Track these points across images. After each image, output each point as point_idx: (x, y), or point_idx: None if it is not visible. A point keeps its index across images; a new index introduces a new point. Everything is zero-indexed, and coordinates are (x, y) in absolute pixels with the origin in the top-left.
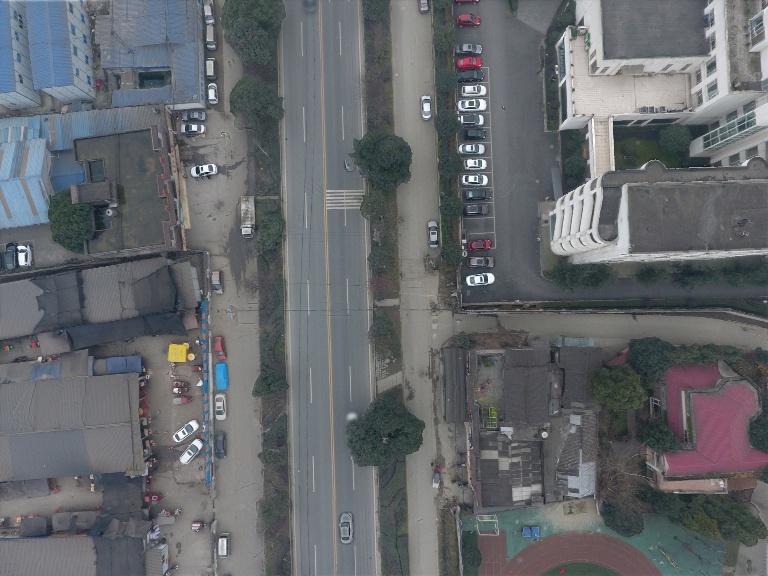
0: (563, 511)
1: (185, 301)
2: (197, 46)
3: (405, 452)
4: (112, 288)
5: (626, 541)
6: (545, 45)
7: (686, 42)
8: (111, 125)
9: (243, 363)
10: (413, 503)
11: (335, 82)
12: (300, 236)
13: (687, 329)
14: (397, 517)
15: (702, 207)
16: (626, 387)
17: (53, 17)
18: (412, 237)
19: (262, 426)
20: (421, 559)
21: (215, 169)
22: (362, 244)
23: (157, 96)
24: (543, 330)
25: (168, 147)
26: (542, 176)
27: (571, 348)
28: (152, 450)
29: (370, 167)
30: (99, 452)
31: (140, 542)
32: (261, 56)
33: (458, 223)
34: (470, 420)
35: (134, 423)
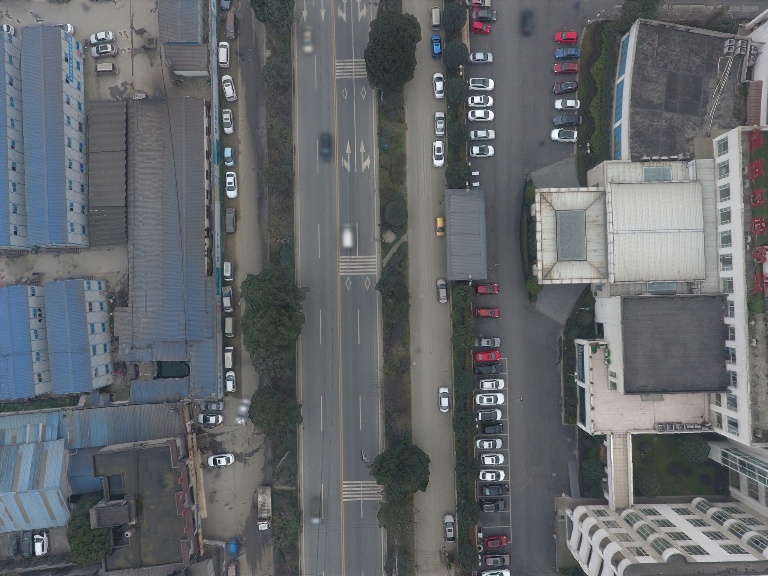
0: None
1: None
2: (216, 343)
3: None
4: None
5: None
6: (564, 337)
7: (707, 372)
8: (129, 422)
9: None
10: None
11: (353, 371)
12: (316, 527)
13: None
14: None
15: None
16: None
17: (73, 323)
18: (428, 528)
19: None
20: None
21: (232, 460)
22: (378, 536)
23: (175, 391)
24: None
25: (186, 450)
26: (559, 470)
27: None
28: None
29: (388, 484)
30: None
31: None
32: (281, 373)
33: None
34: None
35: None
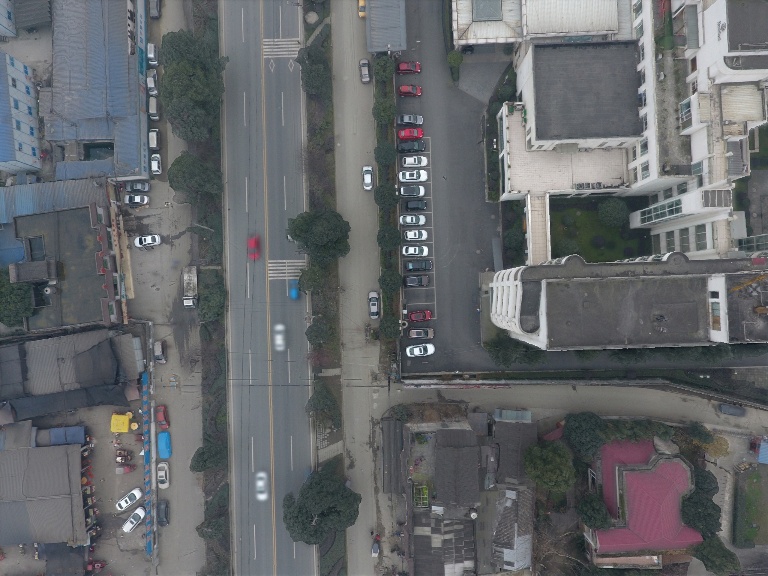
0: None
1: (126, 373)
2: (139, 119)
3: (340, 527)
4: (54, 360)
5: None
6: (487, 115)
7: (620, 121)
8: (54, 198)
9: (186, 431)
10: (353, 571)
11: (277, 152)
12: (242, 306)
13: (627, 400)
14: None
15: (622, 301)
16: (553, 471)
17: None
18: (353, 307)
19: (204, 494)
20: None
21: (158, 240)
22: (304, 314)
23: (100, 168)
24: (483, 400)
25: (109, 221)
26: (483, 246)
27: (506, 424)
28: (96, 518)
29: (306, 244)
30: (43, 521)
31: None
32: (198, 134)
33: (398, 295)
34: (406, 494)
35: (75, 495)
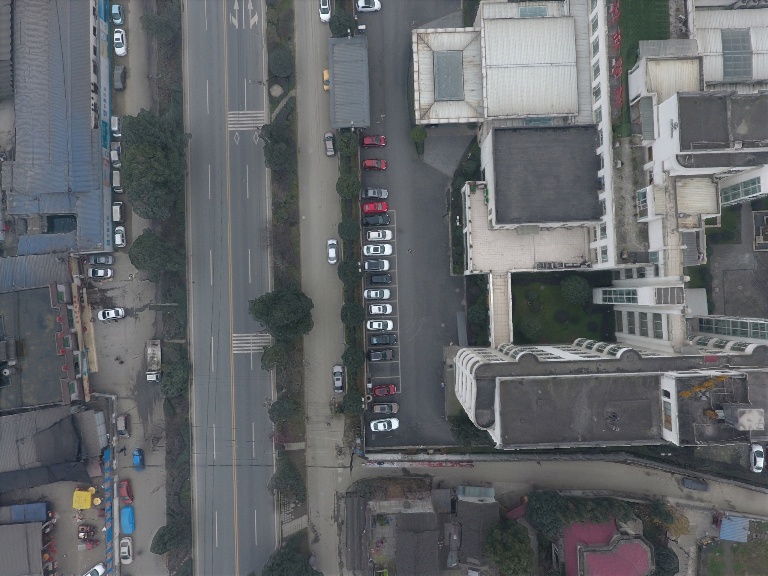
0: None
1: (88, 450)
2: (102, 194)
3: None
4: (15, 438)
5: None
6: (451, 189)
7: (580, 204)
8: (16, 273)
9: (150, 506)
10: None
11: (242, 225)
12: (206, 380)
13: (590, 473)
14: None
15: (575, 398)
16: (512, 558)
17: None
18: (318, 380)
19: (168, 569)
20: None
21: (122, 313)
22: (268, 388)
23: (62, 243)
24: (448, 474)
25: (71, 297)
26: (447, 320)
27: (468, 504)
28: None
29: (268, 323)
30: None
31: None
32: (159, 213)
33: (362, 370)
34: None
35: (35, 575)
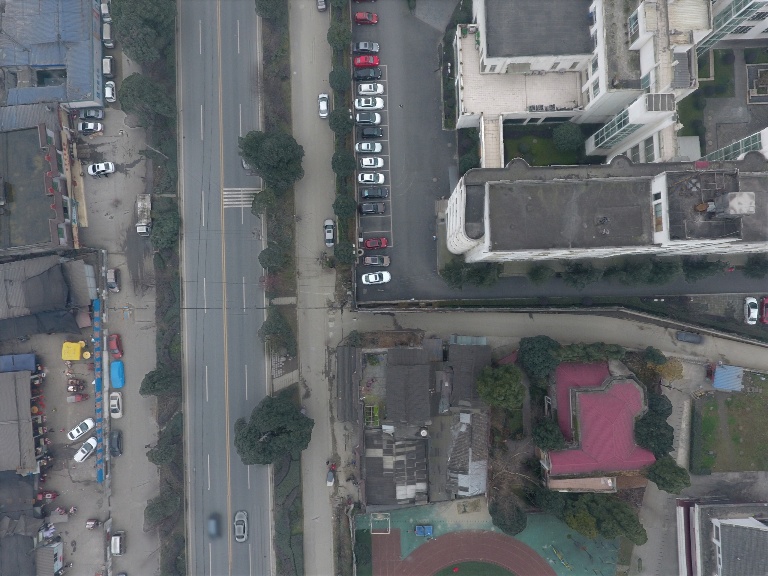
0: (457, 510)
1: (78, 299)
2: (92, 44)
3: (291, 450)
4: (4, 286)
5: (520, 540)
6: (443, 43)
7: (571, 40)
8: (5, 123)
9: (140, 361)
10: (309, 501)
11: (233, 80)
12: (197, 234)
13: (583, 328)
14: (292, 515)
15: (565, 205)
16: (503, 385)
17: None
18: (309, 235)
19: (158, 424)
20: (316, 557)
21: (112, 167)
22: (259, 242)
23: (52, 94)
24: (440, 329)
25: (60, 145)
26: (439, 174)
27: (459, 346)
28: (47, 448)
29: (258, 165)
30: None
31: (30, 540)
32: (149, 54)
33: (353, 221)
34: None
35: (23, 421)
